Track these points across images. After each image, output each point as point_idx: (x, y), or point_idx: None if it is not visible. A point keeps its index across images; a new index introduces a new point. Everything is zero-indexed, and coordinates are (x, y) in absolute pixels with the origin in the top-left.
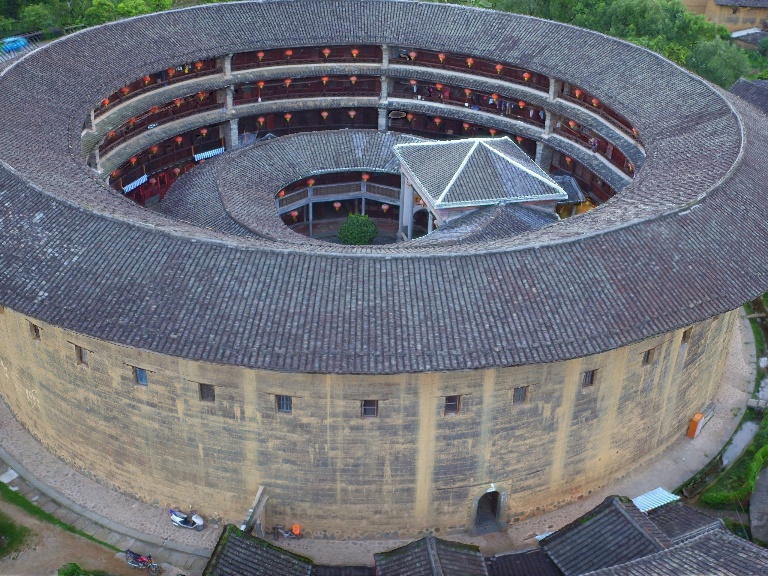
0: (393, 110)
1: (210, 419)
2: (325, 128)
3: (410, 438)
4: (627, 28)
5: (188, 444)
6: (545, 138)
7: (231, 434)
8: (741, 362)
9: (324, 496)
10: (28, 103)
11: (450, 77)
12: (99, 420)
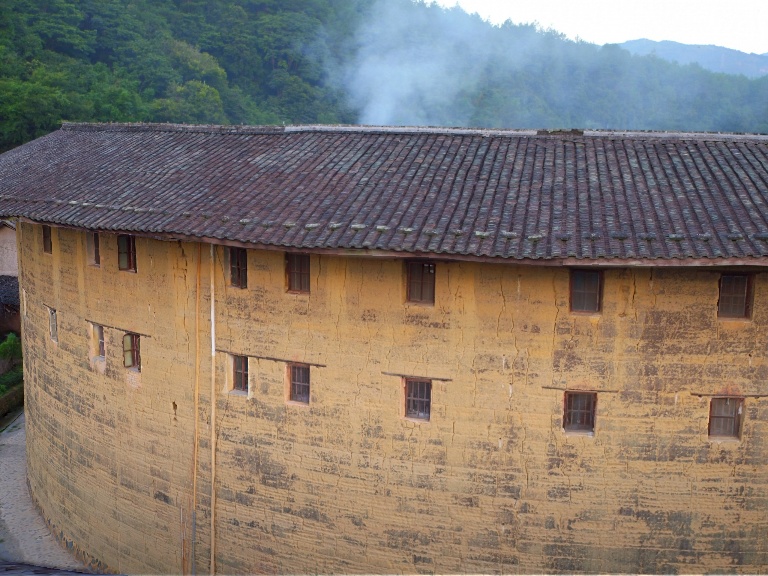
0: None
1: None
2: None
3: None
4: None
5: None
6: None
7: None
8: (4, 467)
9: None
10: None
11: None
12: None
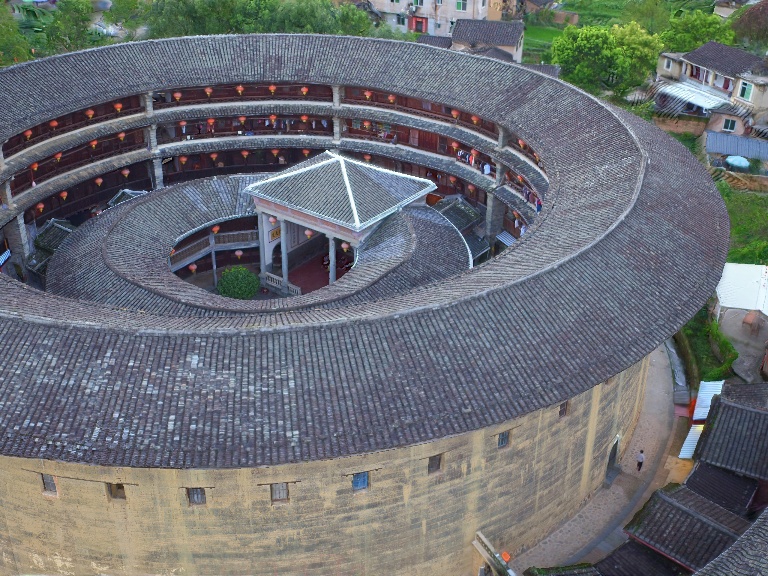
0: (169, 157)
1: (437, 489)
2: (97, 196)
3: (585, 422)
4: (305, 29)
5: (411, 527)
6: (338, 144)
7: (456, 494)
8: None
9: (526, 512)
10: None
11: (221, 109)
12: (297, 555)
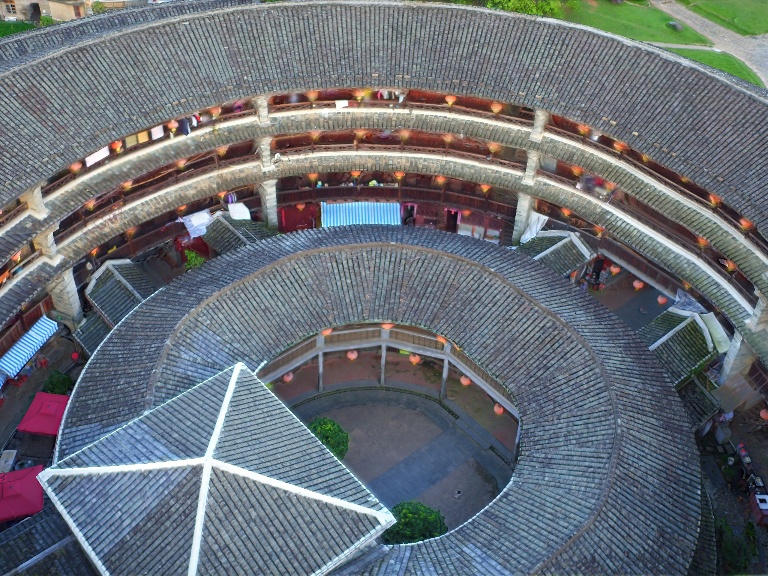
0: None
1: None
2: None
3: None
4: None
5: None
6: None
7: None
8: None
9: None
10: (759, 144)
11: None
12: None
